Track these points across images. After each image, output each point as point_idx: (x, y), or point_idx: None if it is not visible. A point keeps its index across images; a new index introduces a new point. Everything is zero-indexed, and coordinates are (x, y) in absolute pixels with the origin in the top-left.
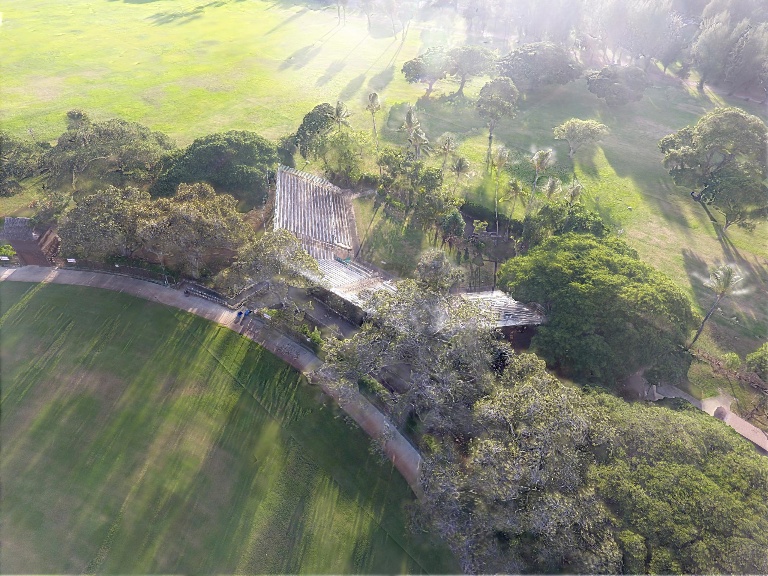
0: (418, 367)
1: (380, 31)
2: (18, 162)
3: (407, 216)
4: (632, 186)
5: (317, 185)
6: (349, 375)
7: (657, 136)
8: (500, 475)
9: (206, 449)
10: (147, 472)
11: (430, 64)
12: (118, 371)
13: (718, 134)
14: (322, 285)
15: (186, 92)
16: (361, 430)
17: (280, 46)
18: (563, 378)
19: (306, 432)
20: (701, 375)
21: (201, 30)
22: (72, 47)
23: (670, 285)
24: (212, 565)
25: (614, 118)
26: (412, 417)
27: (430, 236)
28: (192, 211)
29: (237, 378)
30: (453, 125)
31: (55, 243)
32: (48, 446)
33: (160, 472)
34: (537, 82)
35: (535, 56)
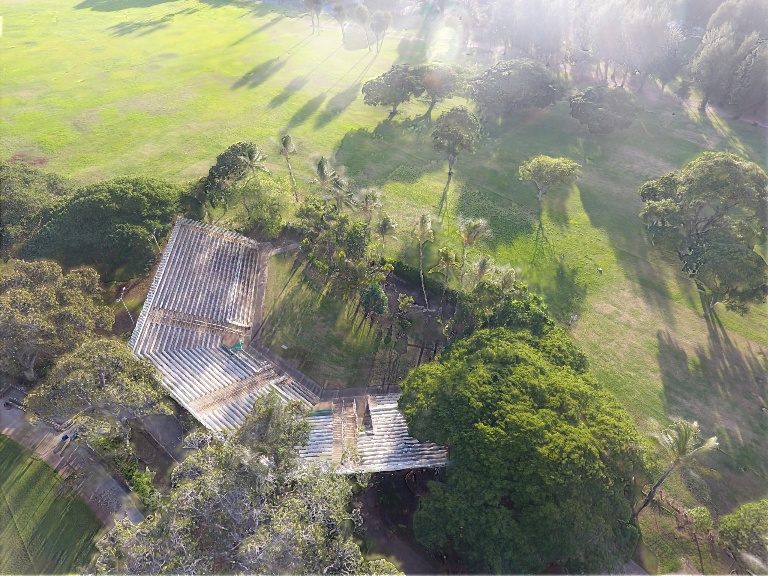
0: None
1: (355, 41)
2: None
3: (329, 280)
4: (607, 239)
5: (227, 240)
6: None
7: (645, 171)
8: None
9: None
10: None
11: (391, 85)
12: None
13: (706, 186)
14: (156, 412)
15: (122, 115)
16: None
17: (242, 60)
18: (457, 563)
19: None
20: (660, 534)
21: (163, 41)
22: (18, 62)
23: (615, 425)
24: None
25: (598, 148)
26: None
27: (350, 309)
28: (1, 309)
29: (27, 546)
30: (411, 157)
31: None
32: None
33: None
34: (511, 106)
35: (509, 76)
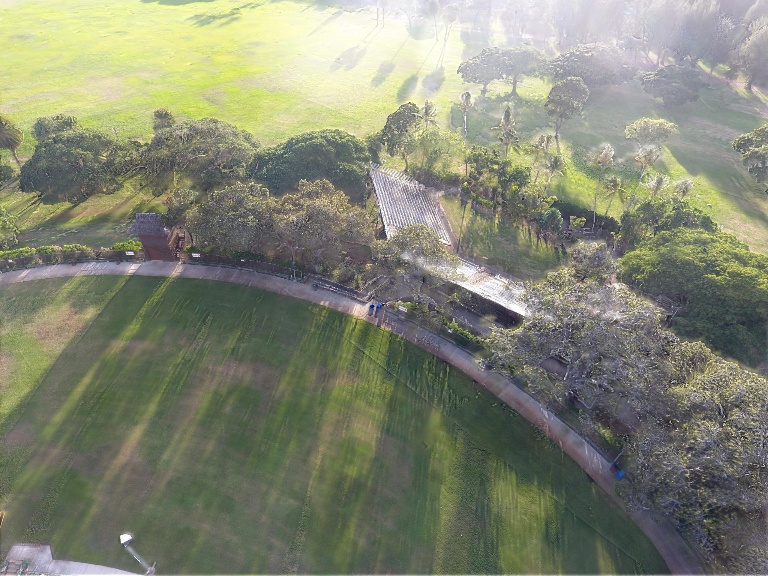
0: (609, 353)
1: (420, 32)
2: (117, 160)
3: (496, 213)
4: (706, 184)
5: (405, 183)
6: (532, 362)
7: (718, 135)
8: (726, 453)
9: (375, 436)
10: (323, 458)
11: (488, 65)
12: (268, 362)
13: None
14: (459, 278)
15: (246, 92)
16: (522, 417)
17: (326, 47)
18: None
19: (468, 419)
20: None
21: (244, 31)
22: (121, 48)
23: None
24: (411, 545)
25: (671, 118)
26: (574, 404)
27: (524, 232)
28: (328, 206)
29: (387, 368)
30: None
31: (177, 238)
32: (220, 433)
33: (336, 458)
34: (594, 82)
35: (592, 57)
